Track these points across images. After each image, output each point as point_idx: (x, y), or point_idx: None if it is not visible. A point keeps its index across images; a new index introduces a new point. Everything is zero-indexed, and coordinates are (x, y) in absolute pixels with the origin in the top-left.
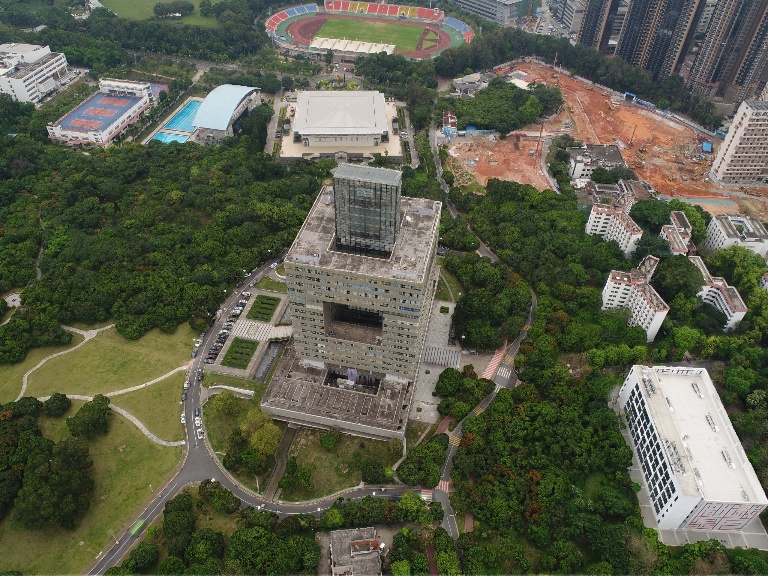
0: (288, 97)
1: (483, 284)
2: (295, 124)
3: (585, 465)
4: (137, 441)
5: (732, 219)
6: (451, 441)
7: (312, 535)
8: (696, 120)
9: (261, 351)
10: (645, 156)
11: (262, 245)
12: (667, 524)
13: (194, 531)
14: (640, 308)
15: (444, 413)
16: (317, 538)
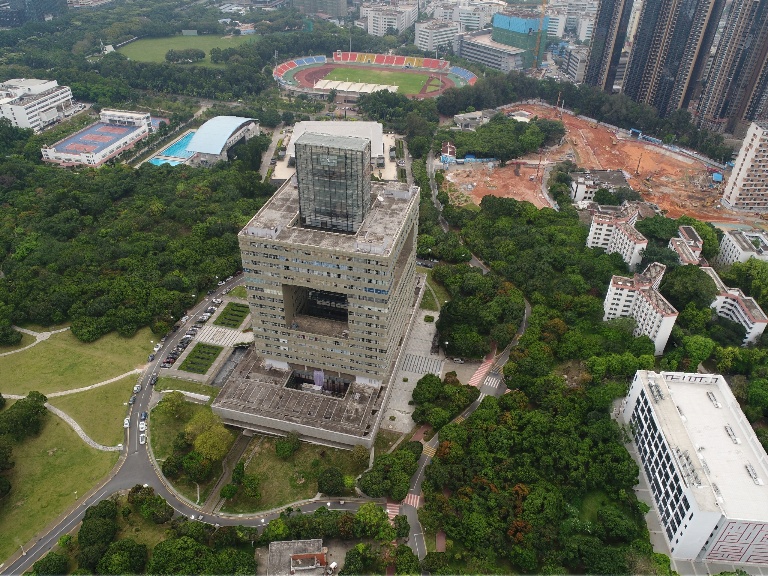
0: (288, 130)
1: (473, 293)
2: (289, 148)
3: (582, 480)
4: (70, 444)
5: (747, 234)
6: (426, 452)
7: (251, 550)
8: (705, 153)
9: (224, 356)
10: (652, 185)
11: (239, 254)
12: (682, 552)
13: (114, 542)
14: (646, 315)
15: (419, 421)
16: (257, 554)
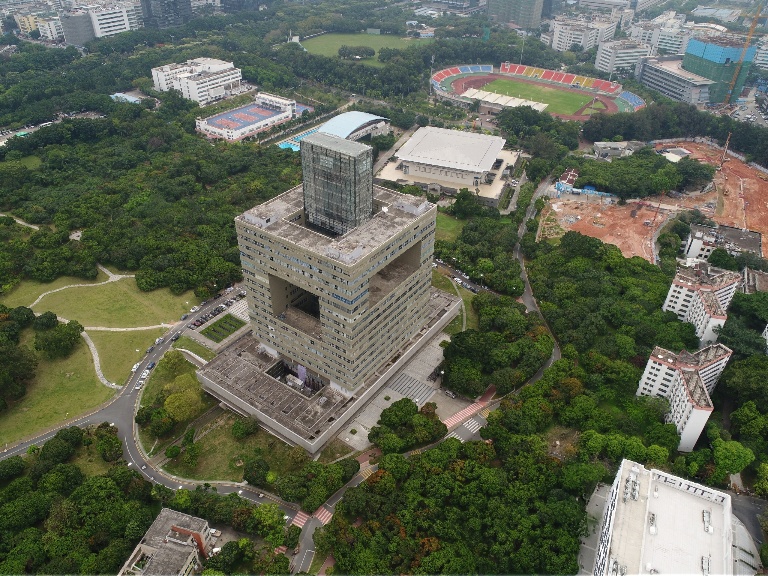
0: None
1: (502, 329)
2: (400, 150)
3: (503, 557)
4: (85, 373)
5: None
6: (365, 474)
7: (159, 510)
8: None
9: (243, 332)
10: None
11: None
12: None
13: None
14: (679, 401)
15: (373, 441)
16: None
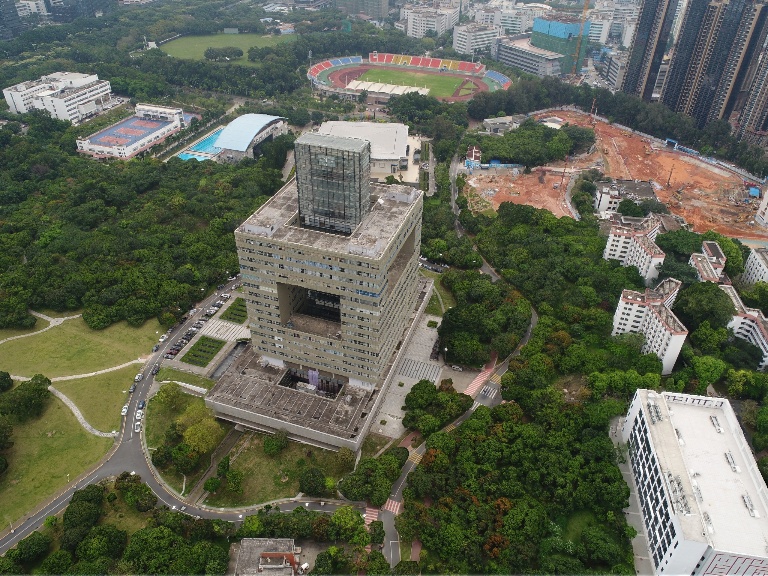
0: (316, 130)
1: (479, 301)
2: None
3: (568, 498)
4: (69, 428)
5: None
6: (412, 458)
7: (226, 545)
8: (744, 167)
9: (226, 351)
10: (683, 197)
11: None
12: None
13: (96, 526)
14: (655, 332)
15: (409, 427)
16: (232, 549)
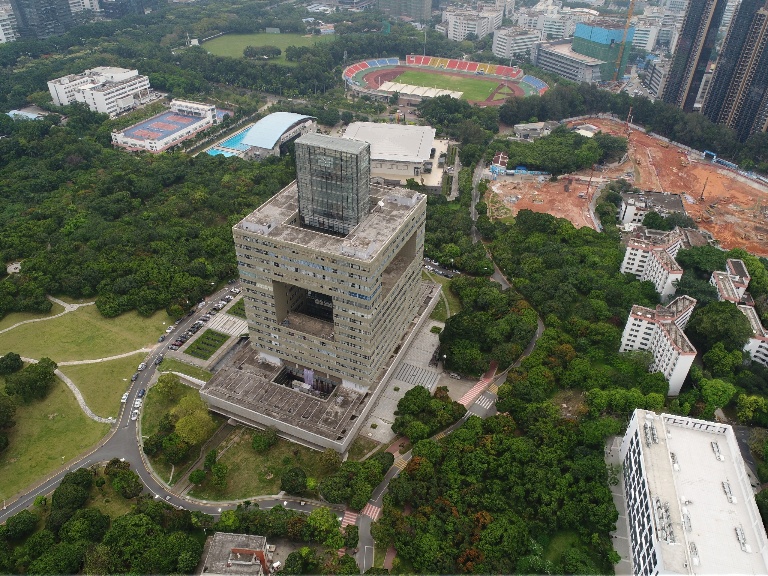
0: (345, 130)
1: (486, 309)
2: None
3: (551, 517)
4: (70, 411)
5: None
6: (398, 464)
7: (203, 537)
8: None
9: (229, 345)
10: (716, 212)
11: None
12: None
13: (82, 509)
14: (663, 351)
15: (398, 432)
16: (208, 542)
